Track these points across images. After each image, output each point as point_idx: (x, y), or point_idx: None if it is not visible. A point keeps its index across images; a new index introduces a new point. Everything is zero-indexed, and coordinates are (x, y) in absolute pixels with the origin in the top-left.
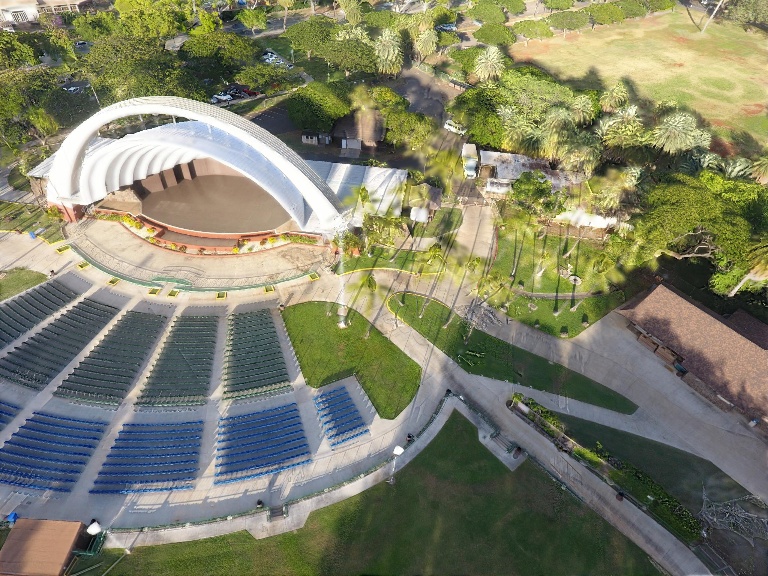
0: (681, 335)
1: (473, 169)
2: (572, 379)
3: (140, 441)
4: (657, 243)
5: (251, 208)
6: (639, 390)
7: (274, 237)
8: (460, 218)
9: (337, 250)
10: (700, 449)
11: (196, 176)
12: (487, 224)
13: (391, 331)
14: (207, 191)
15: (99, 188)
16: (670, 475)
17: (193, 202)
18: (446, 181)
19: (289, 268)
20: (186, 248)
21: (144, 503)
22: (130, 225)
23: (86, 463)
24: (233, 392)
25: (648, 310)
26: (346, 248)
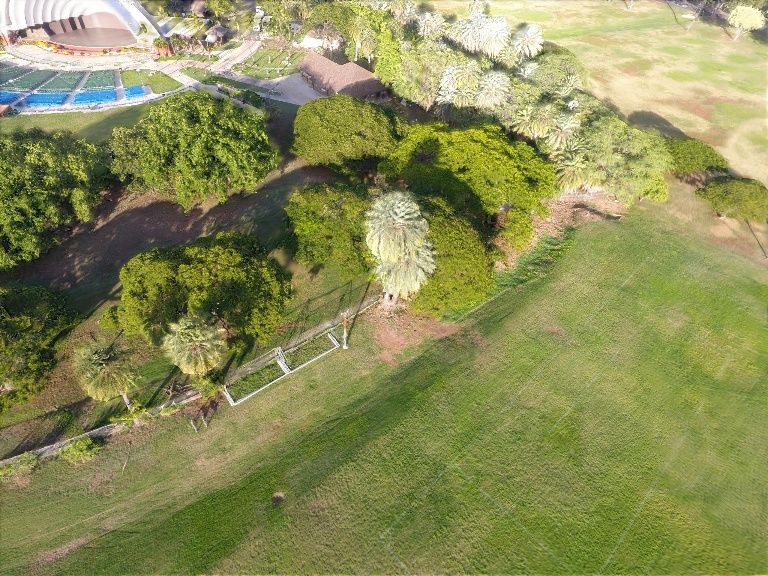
0: (313, 68)
1: (258, 25)
2: (258, 88)
3: (38, 96)
4: (306, 28)
5: (115, 39)
6: (290, 92)
7: (125, 49)
8: (240, 45)
9: (159, 53)
10: (302, 104)
11: (85, 28)
12: (254, 47)
13: (175, 77)
14: (90, 33)
15: (21, 20)
16: (277, 105)
17: (81, 37)
18: (241, 32)
19: (130, 60)
20: (74, 54)
21: (38, 109)
22: (42, 46)
23: (13, 102)
24: (86, 88)
25: (304, 61)
26: (159, 45)
